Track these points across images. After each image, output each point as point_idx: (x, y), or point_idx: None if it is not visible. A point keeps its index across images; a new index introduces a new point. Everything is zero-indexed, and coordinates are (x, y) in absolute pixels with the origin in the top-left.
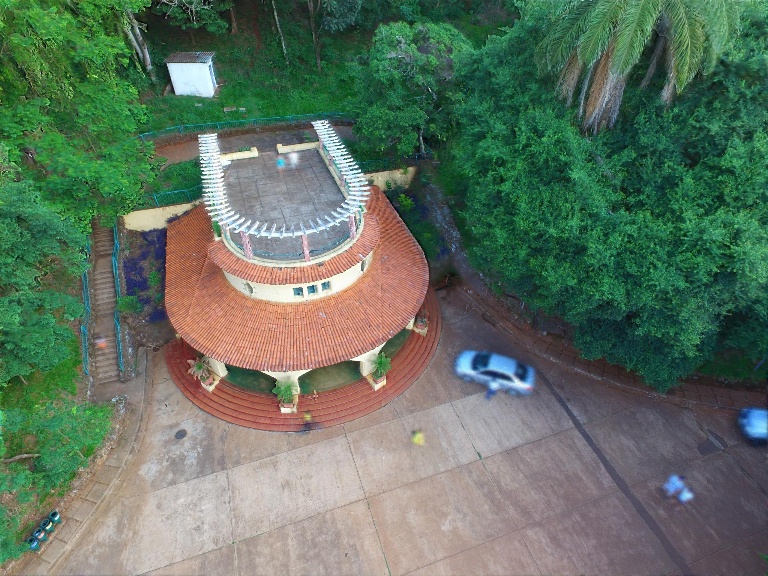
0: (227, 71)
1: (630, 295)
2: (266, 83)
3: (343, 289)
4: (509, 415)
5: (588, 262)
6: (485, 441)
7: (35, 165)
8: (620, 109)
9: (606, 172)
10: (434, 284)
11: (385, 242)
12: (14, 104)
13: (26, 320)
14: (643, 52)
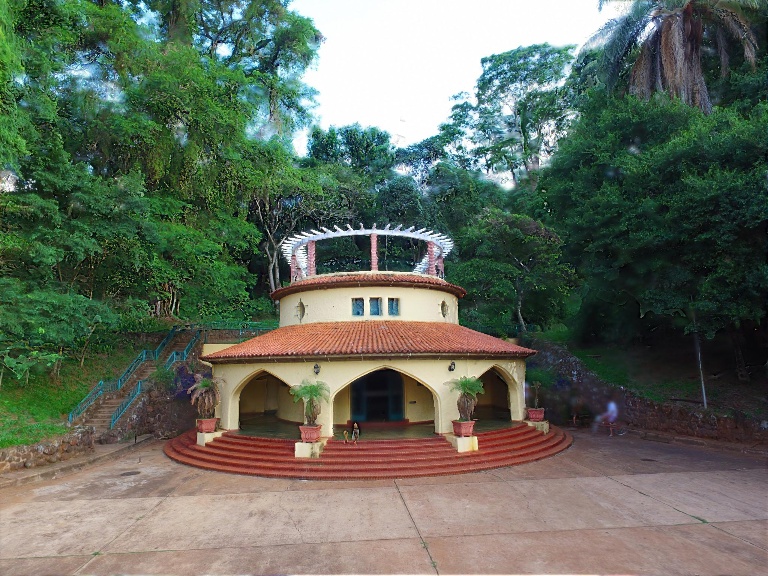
0: None
1: None
2: None
3: (416, 321)
4: (747, 490)
5: (741, 137)
6: (705, 507)
7: None
8: None
9: None
10: (555, 424)
11: None
12: None
13: None
14: None
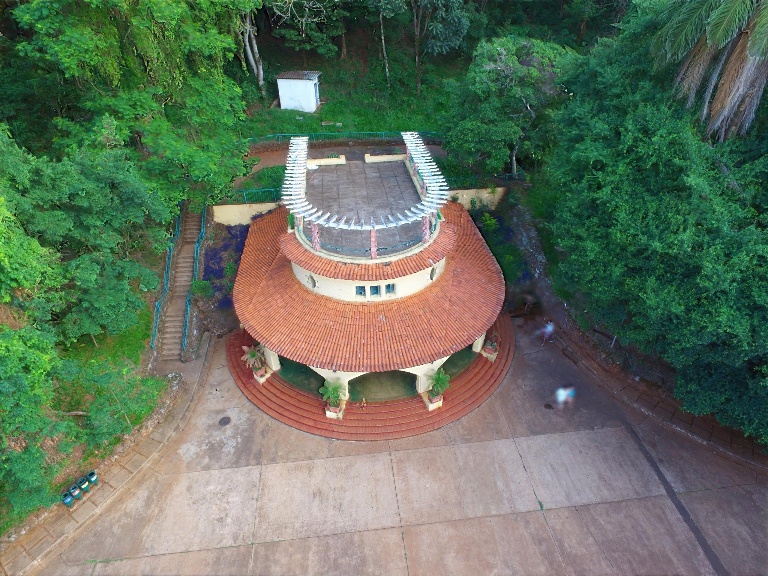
0: (331, 91)
1: (756, 332)
2: (365, 101)
3: (408, 295)
4: (583, 465)
5: (701, 284)
6: (550, 490)
7: (142, 149)
8: (757, 114)
9: (733, 185)
10: (511, 310)
11: (461, 256)
12: (132, 90)
13: (105, 284)
14: None
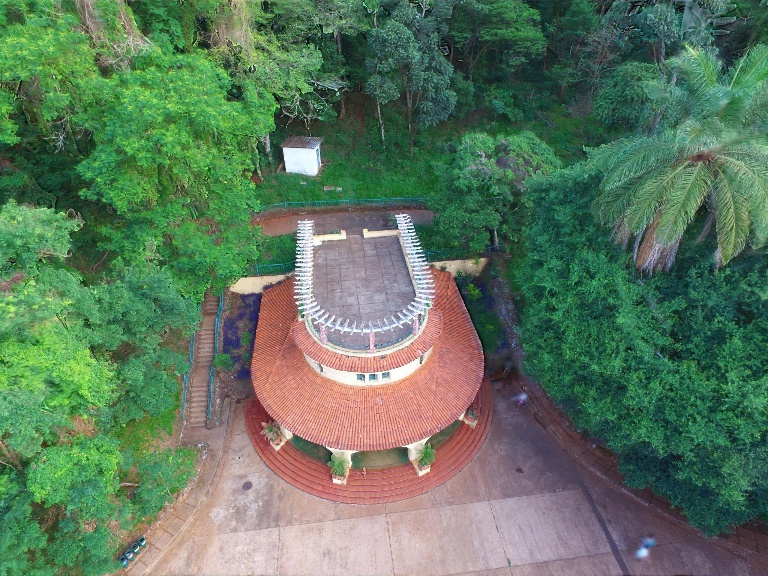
0: (331, 152)
1: (669, 440)
2: (363, 167)
3: (401, 379)
4: (545, 526)
5: (627, 403)
6: (517, 548)
7: (171, 244)
8: (677, 256)
9: None
10: (491, 374)
11: (447, 334)
12: (165, 201)
13: (146, 373)
14: (699, 213)
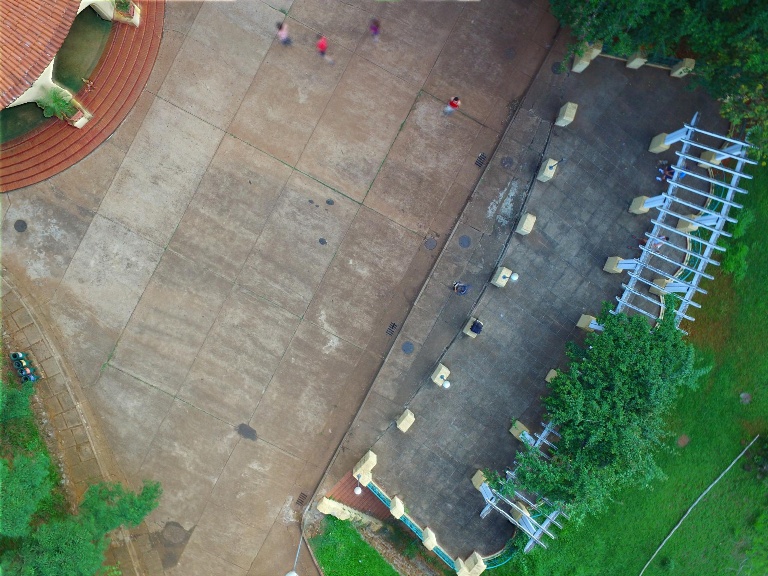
0: None
1: None
2: None
3: None
4: None
5: None
6: None
7: None
8: None
9: None
10: None
11: None
12: None
13: None
14: None
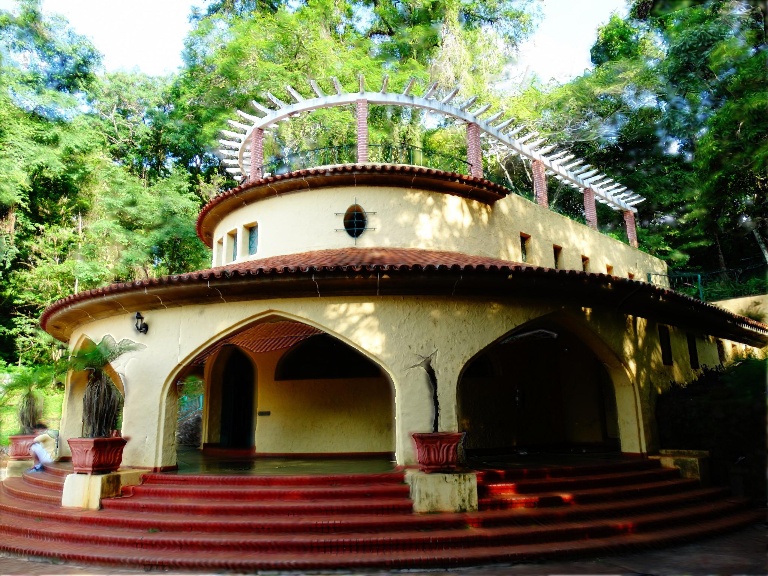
0: None
1: None
2: None
3: (280, 255)
4: None
5: None
6: None
7: None
8: None
9: None
10: None
11: None
12: None
13: None
14: None
